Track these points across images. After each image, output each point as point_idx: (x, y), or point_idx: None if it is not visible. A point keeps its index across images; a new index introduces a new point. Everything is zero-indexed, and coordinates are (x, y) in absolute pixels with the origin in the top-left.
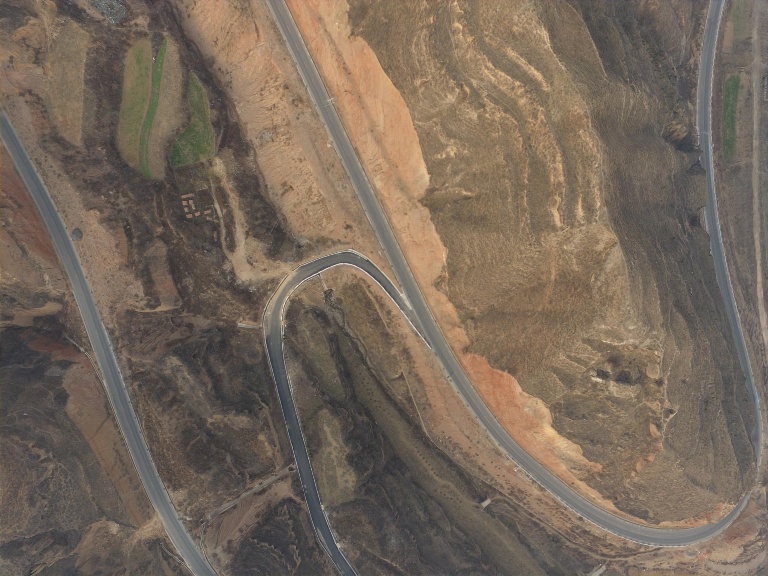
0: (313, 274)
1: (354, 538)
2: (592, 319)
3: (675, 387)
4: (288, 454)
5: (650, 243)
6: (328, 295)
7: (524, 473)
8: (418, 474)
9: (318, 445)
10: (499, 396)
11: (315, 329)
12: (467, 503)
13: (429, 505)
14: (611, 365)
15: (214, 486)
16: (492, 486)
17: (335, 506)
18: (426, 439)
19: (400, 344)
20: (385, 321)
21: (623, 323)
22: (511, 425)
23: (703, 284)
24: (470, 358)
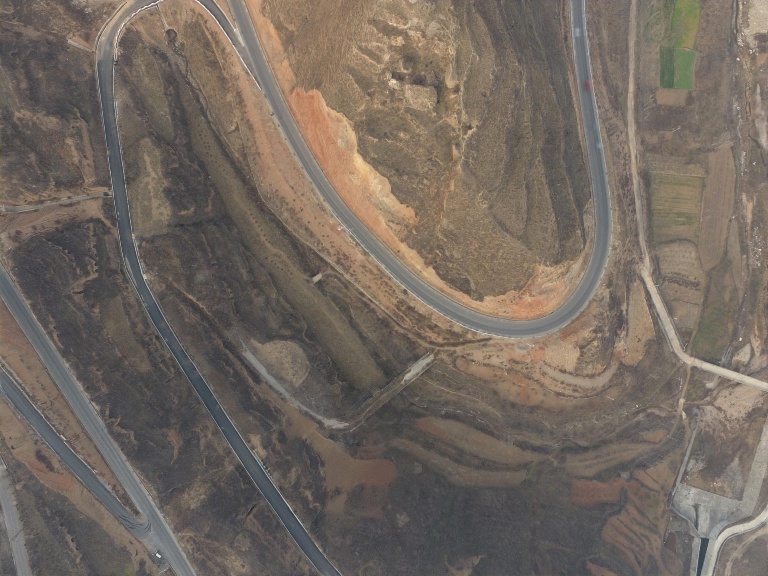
0: (151, 3)
1: (161, 270)
2: None
3: (474, 99)
4: (104, 177)
5: None
6: (172, 40)
7: (348, 233)
8: (249, 238)
9: (136, 173)
10: (320, 136)
11: (151, 64)
12: (298, 276)
13: (255, 268)
14: (402, 60)
15: (8, 172)
16: (323, 258)
17: (146, 237)
18: (261, 203)
19: (233, 87)
20: (221, 62)
21: None
22: (335, 176)
23: (534, 30)
24: (295, 96)
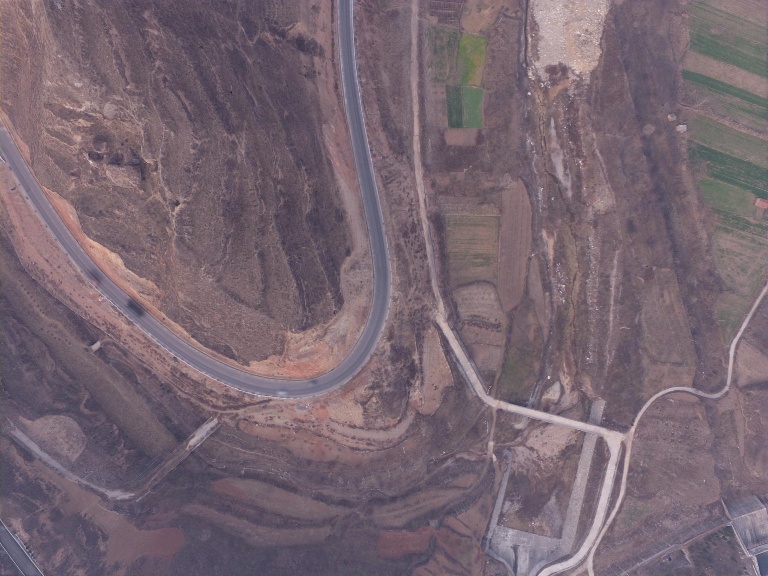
0: None
1: None
2: (42, 76)
3: (176, 175)
4: None
5: (122, 4)
6: None
7: (109, 304)
8: (22, 310)
9: None
10: None
11: None
12: (77, 345)
13: (28, 341)
14: (91, 141)
15: None
16: None
17: None
18: None
19: None
20: None
21: (65, 77)
22: (86, 247)
23: (264, 91)
24: None
